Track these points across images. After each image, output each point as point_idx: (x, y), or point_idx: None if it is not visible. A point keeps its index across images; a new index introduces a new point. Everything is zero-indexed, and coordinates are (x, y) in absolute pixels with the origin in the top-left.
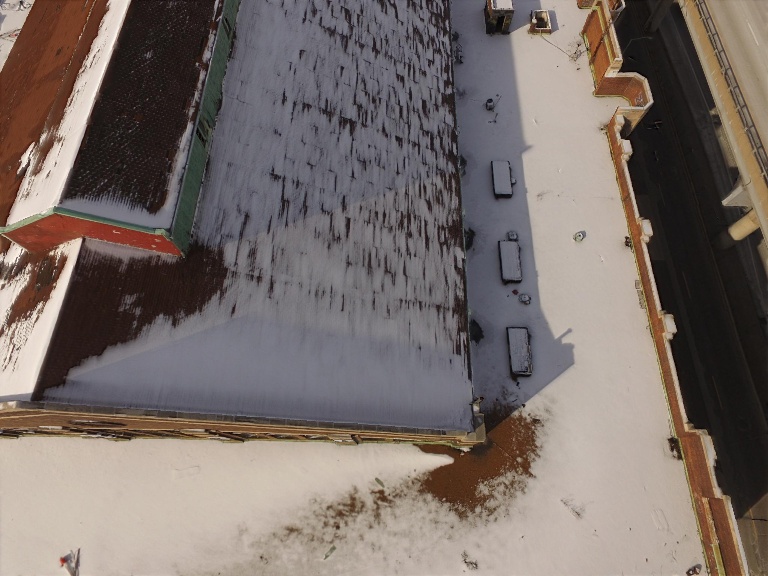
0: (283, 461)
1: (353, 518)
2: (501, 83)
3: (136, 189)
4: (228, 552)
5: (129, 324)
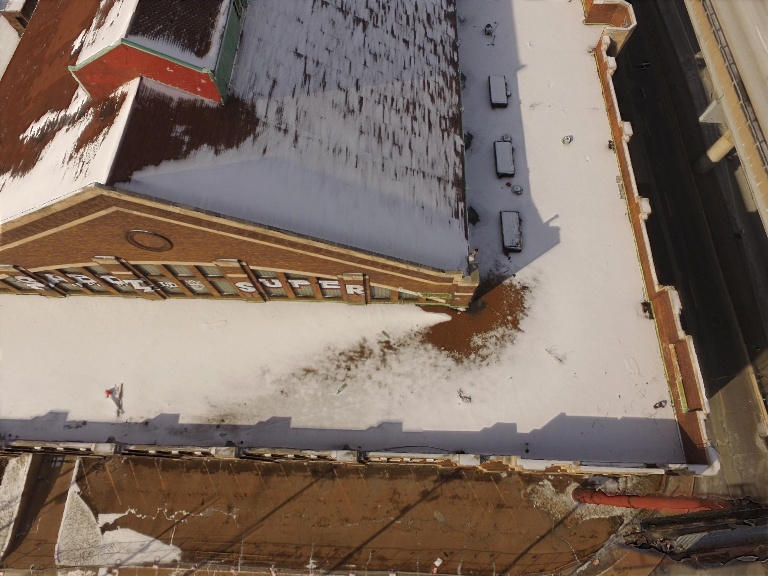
0: (301, 317)
1: (362, 362)
2: (499, 12)
3: (186, 37)
4: (253, 387)
5: (180, 147)
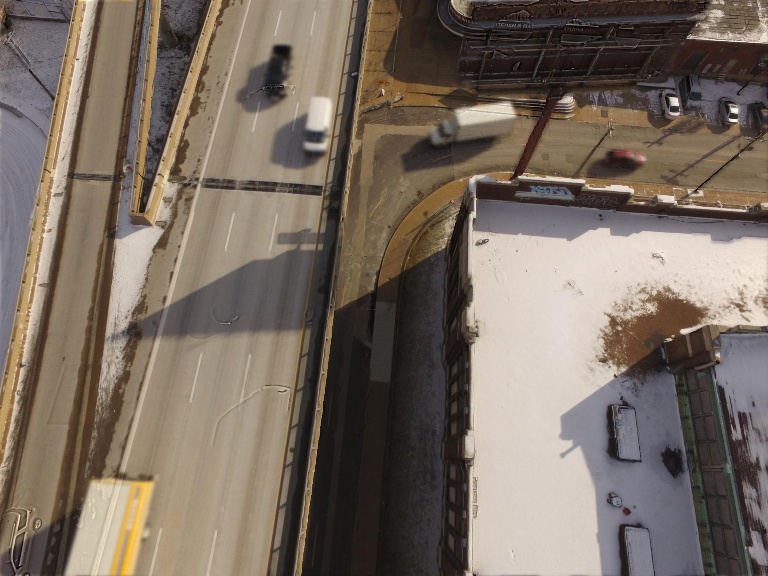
0: None
1: (762, 293)
2: None
3: None
4: None
5: None
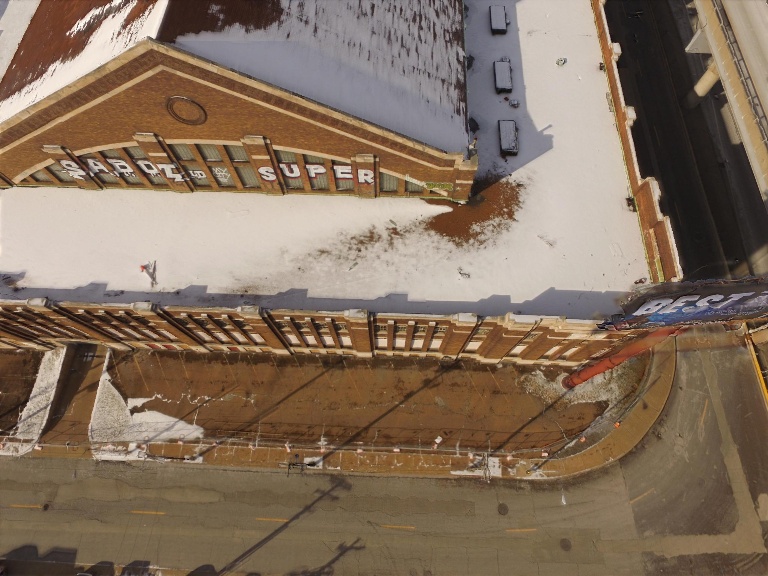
0: (316, 208)
1: (372, 245)
2: None
3: None
4: (273, 265)
5: (216, 22)
